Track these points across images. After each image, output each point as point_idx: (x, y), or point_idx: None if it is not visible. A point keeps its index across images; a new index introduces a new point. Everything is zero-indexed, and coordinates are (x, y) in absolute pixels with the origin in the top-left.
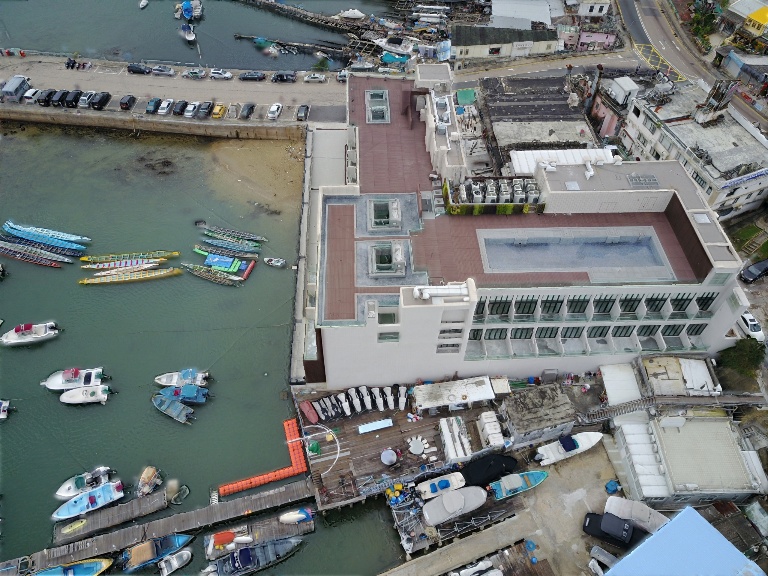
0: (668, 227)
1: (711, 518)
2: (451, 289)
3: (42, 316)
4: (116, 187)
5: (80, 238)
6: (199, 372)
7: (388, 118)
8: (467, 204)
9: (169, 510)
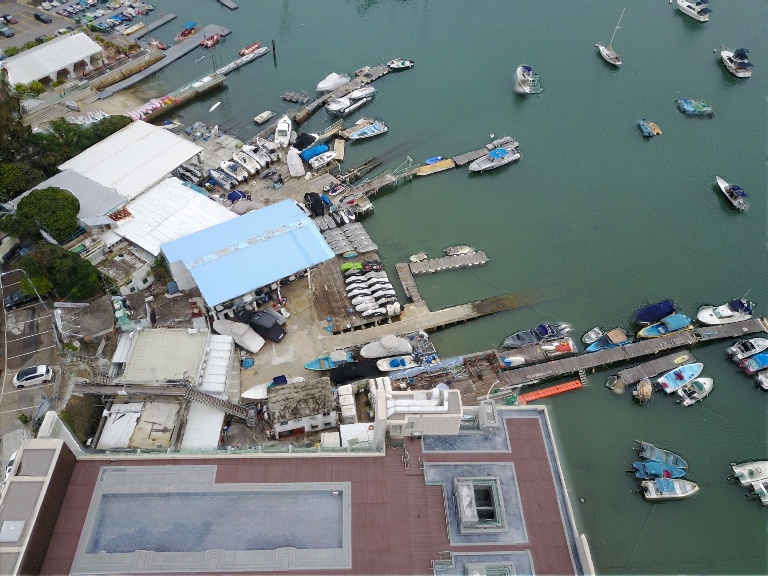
0: (45, 574)
1: (185, 324)
2: (406, 405)
3: None
4: None
5: None
6: (658, 515)
7: None
8: None
9: (615, 372)
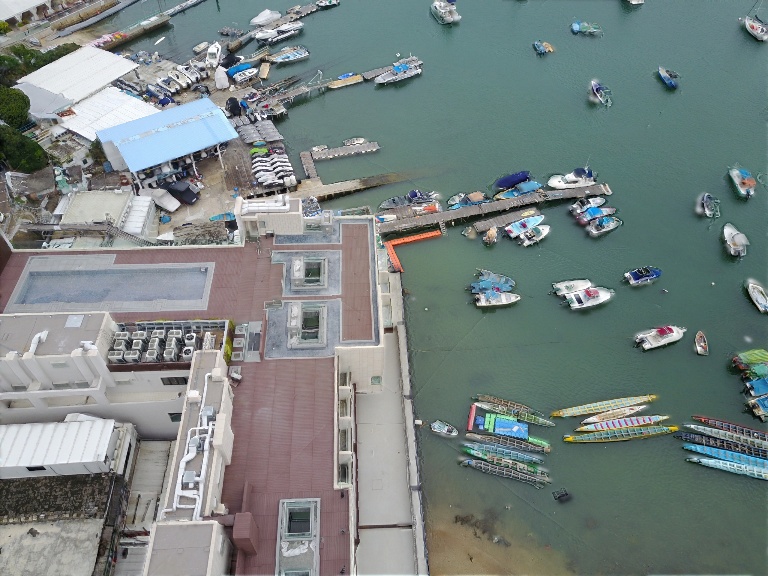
0: None
1: None
2: (257, 206)
3: (667, 363)
4: (726, 575)
5: (701, 461)
6: (489, 321)
7: (283, 512)
8: (209, 320)
9: (471, 224)
